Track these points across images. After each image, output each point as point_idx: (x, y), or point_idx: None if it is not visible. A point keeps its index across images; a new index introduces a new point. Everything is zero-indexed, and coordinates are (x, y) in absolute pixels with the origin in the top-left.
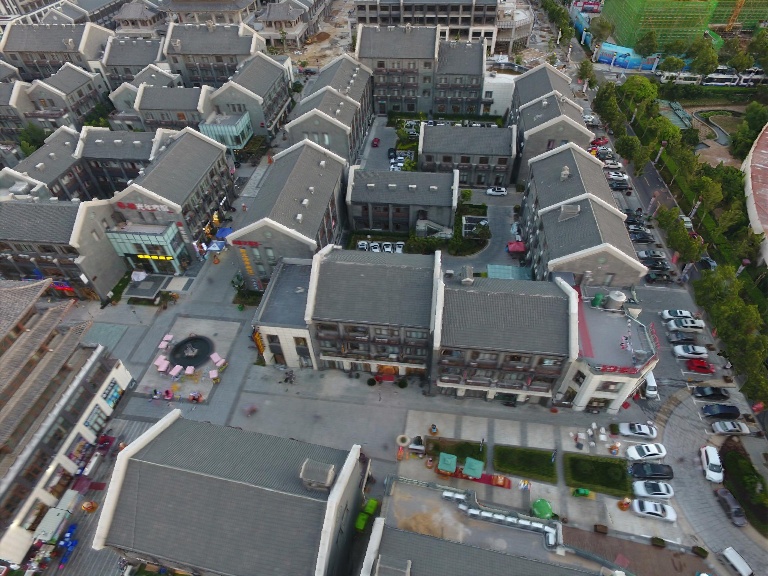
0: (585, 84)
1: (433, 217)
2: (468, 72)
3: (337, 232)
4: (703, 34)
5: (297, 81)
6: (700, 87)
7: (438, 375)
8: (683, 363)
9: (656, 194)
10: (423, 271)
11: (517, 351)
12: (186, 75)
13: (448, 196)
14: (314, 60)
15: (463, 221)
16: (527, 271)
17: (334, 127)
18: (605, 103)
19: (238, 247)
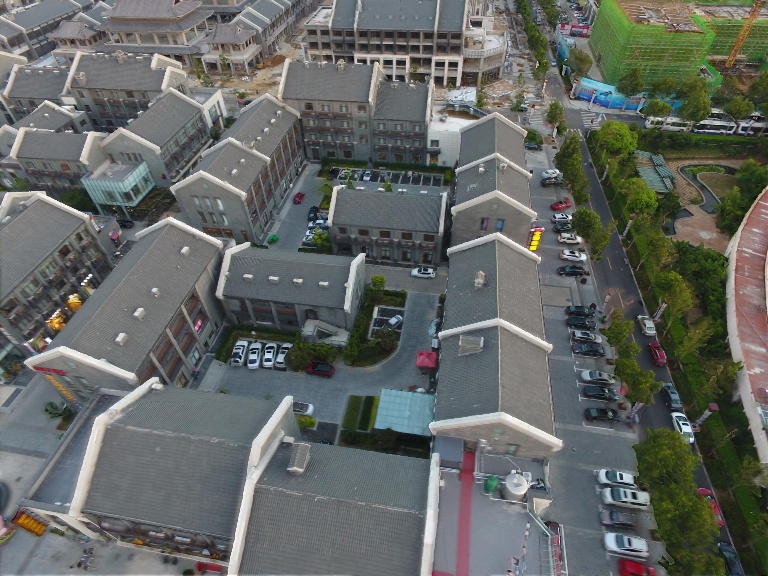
0: (555, 129)
1: (325, 317)
2: (409, 118)
3: (210, 329)
4: (698, 70)
5: (230, 116)
6: (689, 136)
7: None
8: (615, 561)
9: (611, 292)
10: (238, 450)
11: None
12: (95, 111)
13: (341, 295)
14: (261, 88)
15: (374, 314)
16: (430, 402)
17: (226, 192)
18: (567, 161)
19: (43, 373)
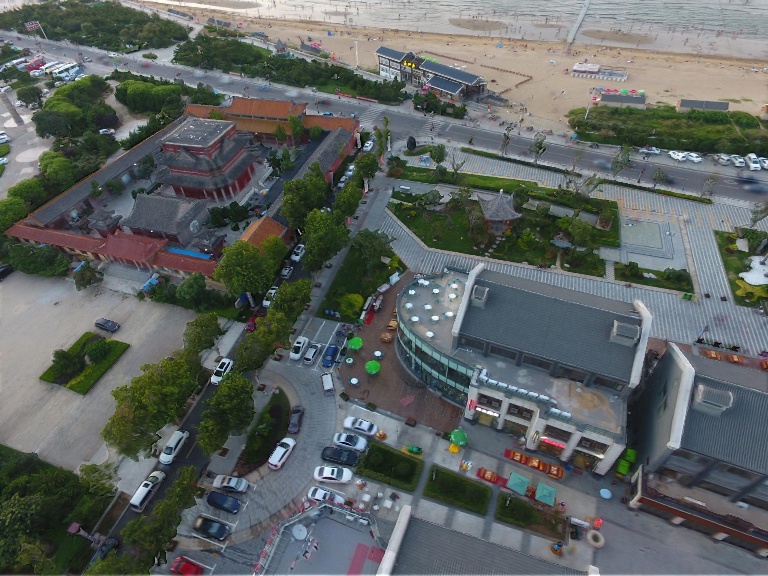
0: None
1: None
2: None
3: None
4: None
5: None
6: None
7: None
8: None
9: None
10: None
11: None
12: None
13: None
14: None
15: None
16: None
17: None
18: None
19: None
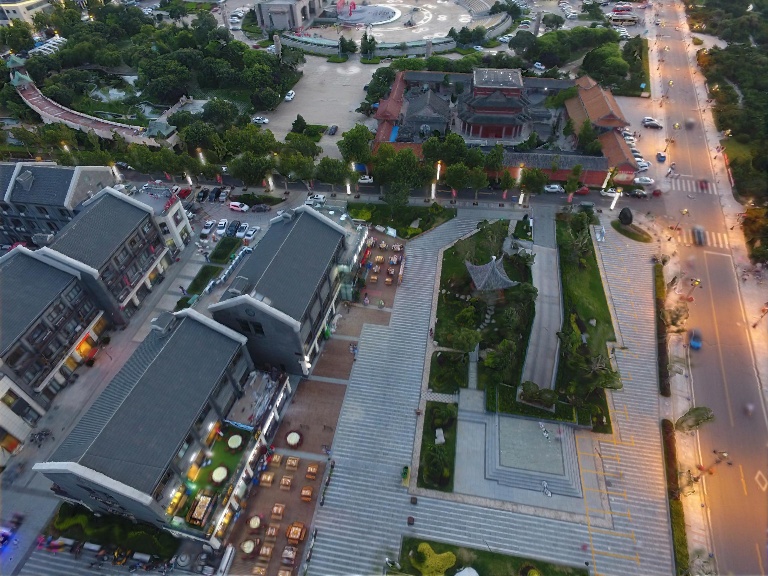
0: None
1: None
2: None
3: None
4: None
5: None
6: None
7: (116, 301)
8: None
9: (39, 158)
10: (16, 260)
11: (130, 234)
12: None
13: None
14: None
15: None
16: None
17: None
18: None
19: None
